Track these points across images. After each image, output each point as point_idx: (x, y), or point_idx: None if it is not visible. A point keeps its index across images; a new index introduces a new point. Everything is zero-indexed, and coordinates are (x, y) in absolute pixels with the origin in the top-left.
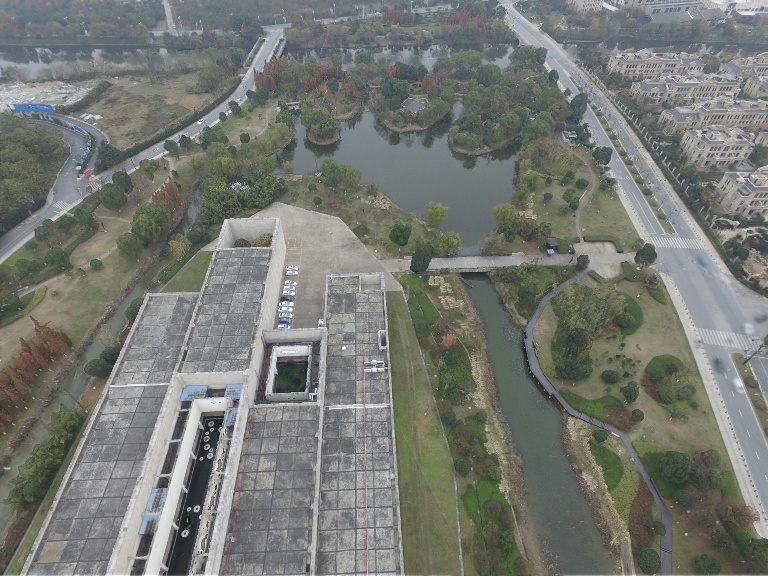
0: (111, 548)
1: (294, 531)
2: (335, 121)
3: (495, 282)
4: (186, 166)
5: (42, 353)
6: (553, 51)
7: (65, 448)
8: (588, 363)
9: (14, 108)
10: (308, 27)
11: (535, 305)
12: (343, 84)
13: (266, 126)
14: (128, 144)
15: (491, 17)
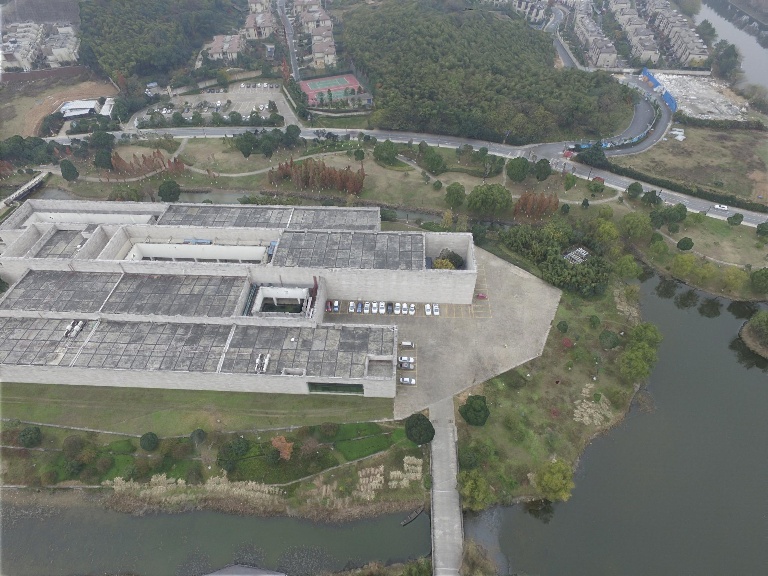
0: None
1: (143, 306)
2: None
3: (408, 564)
4: None
5: (344, 181)
6: None
7: None
8: None
9: (664, 93)
10: None
11: None
12: None
13: None
14: (635, 165)
15: None
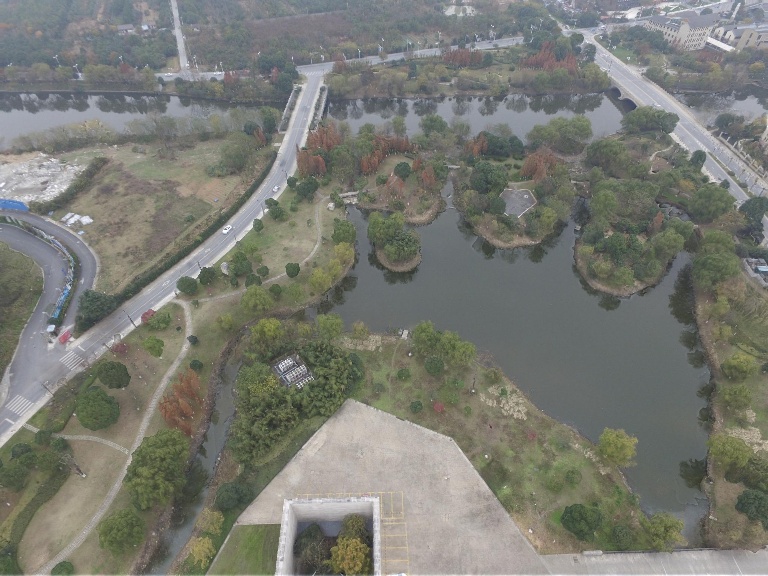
0: None
1: None
2: (416, 235)
3: None
4: (209, 319)
5: None
6: (672, 110)
7: None
8: None
9: None
10: (354, 70)
11: None
12: (414, 165)
13: (318, 240)
14: (126, 274)
15: (576, 56)
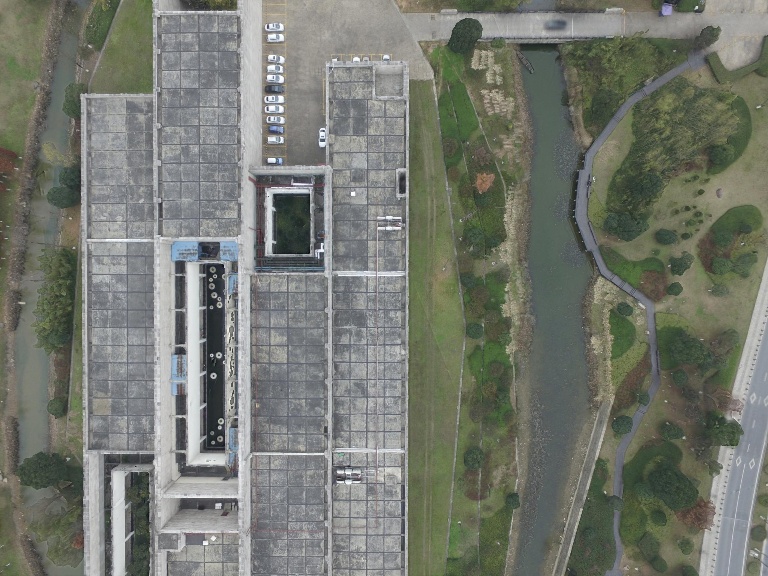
0: (152, 406)
1: (311, 401)
2: None
3: (566, 65)
4: None
5: None
6: None
7: (70, 293)
8: (647, 214)
9: None
10: None
11: (610, 115)
12: None
13: None
14: None
15: None
